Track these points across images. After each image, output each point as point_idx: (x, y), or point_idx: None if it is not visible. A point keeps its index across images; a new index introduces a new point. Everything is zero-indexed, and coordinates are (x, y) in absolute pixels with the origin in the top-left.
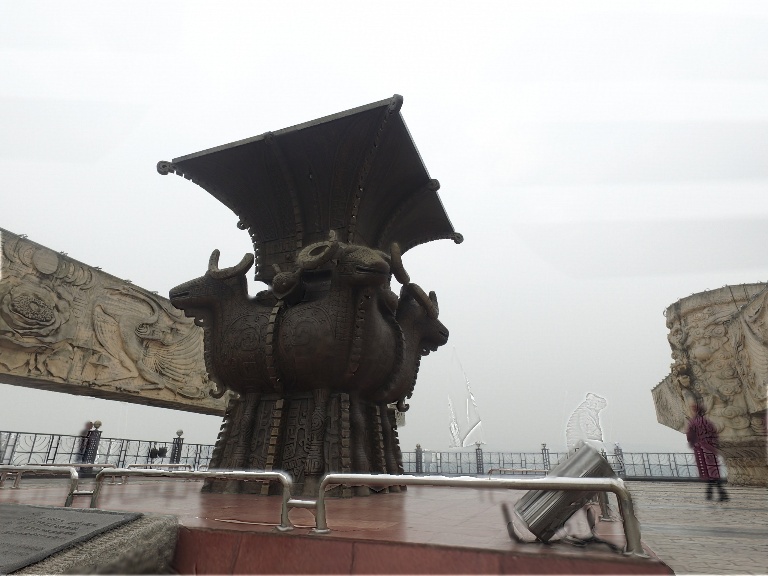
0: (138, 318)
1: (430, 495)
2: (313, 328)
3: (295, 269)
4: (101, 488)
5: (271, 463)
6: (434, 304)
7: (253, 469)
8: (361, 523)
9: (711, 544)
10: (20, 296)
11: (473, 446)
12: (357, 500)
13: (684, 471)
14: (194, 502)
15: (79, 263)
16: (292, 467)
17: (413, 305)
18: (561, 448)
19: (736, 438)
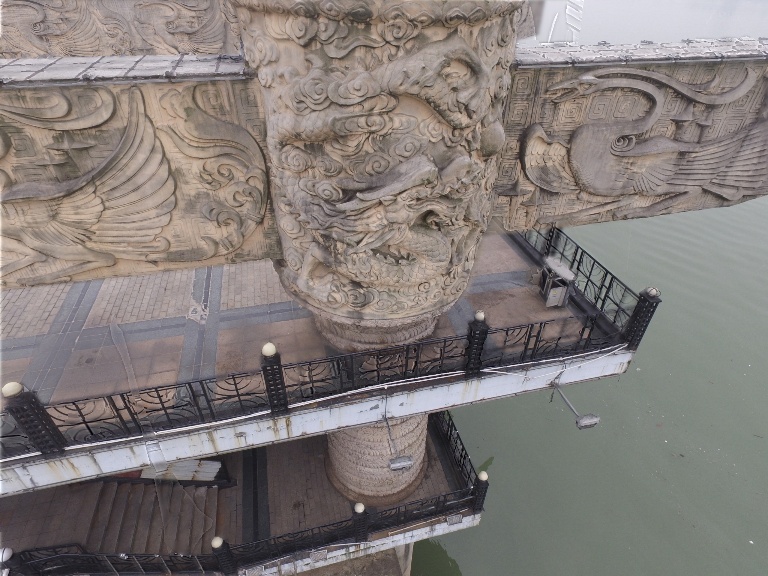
0: (28, 21)
1: None
2: None
3: None
4: None
5: None
6: None
7: None
8: None
9: None
10: None
11: None
12: None
13: (532, 237)
14: None
15: None
16: None
17: None
18: None
19: None
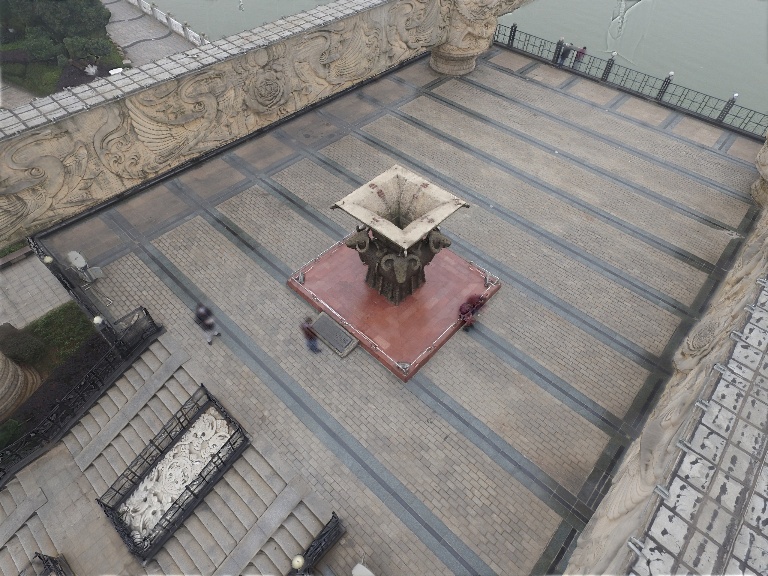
0: (319, 52)
1: (424, 298)
2: (388, 275)
3: (384, 245)
4: (339, 263)
5: (380, 290)
6: (441, 245)
7: (377, 285)
8: (385, 343)
9: (465, 347)
10: (260, 86)
11: (608, 55)
12: (398, 309)
13: None
14: (362, 307)
15: (276, 42)
16: (386, 291)
17: (433, 243)
18: (684, 81)
19: (765, 176)
